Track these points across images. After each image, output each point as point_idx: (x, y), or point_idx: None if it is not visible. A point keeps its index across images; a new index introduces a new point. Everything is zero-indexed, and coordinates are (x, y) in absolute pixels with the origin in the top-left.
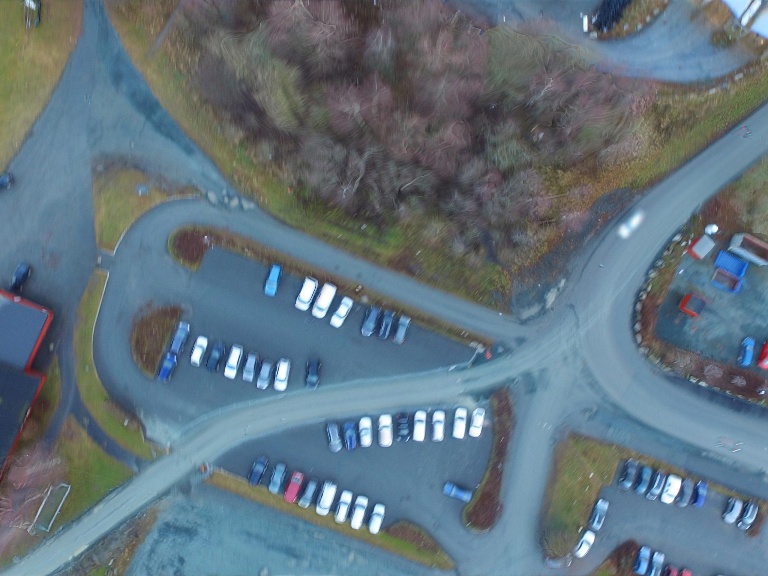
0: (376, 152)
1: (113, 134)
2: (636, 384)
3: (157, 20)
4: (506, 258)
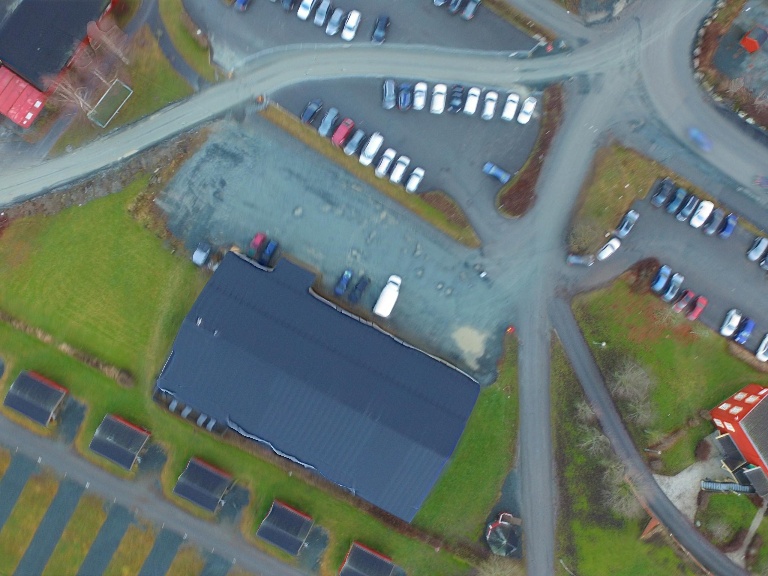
0: None
1: None
2: (686, 107)
3: None
4: None
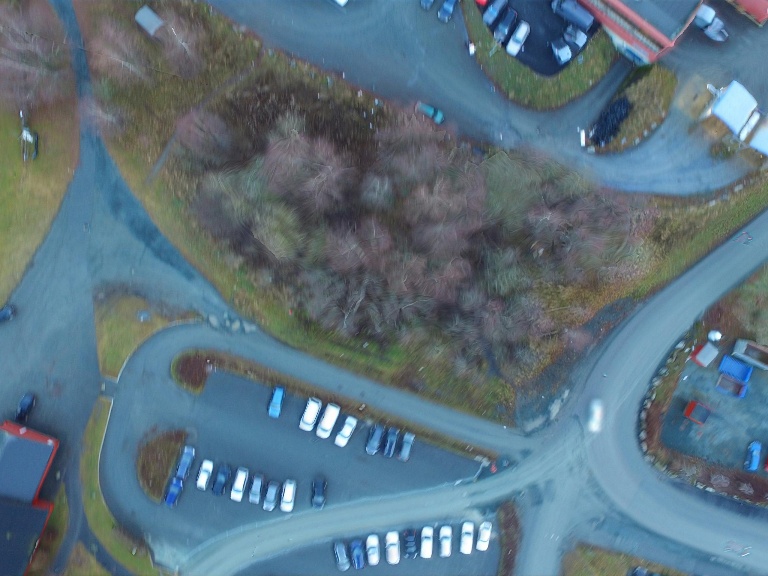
0: (376, 281)
1: (113, 262)
2: (643, 492)
3: (154, 148)
4: (509, 372)
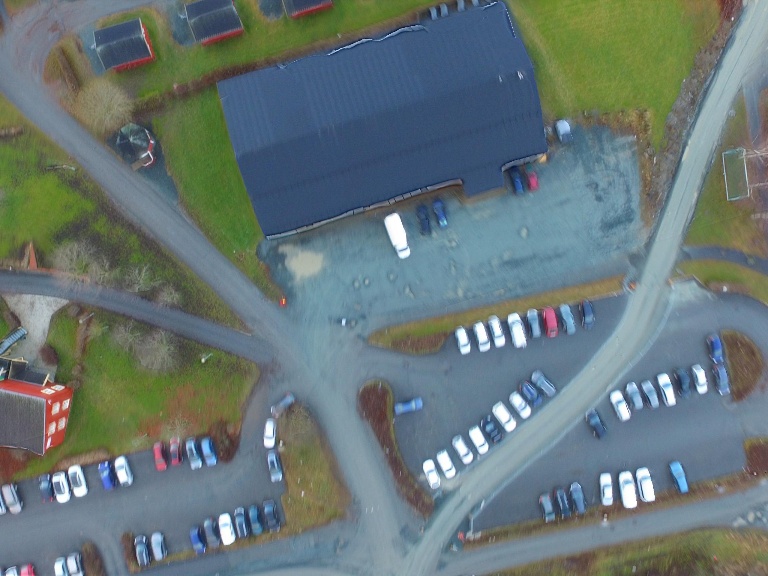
0: None
1: None
2: None
3: None
4: None
